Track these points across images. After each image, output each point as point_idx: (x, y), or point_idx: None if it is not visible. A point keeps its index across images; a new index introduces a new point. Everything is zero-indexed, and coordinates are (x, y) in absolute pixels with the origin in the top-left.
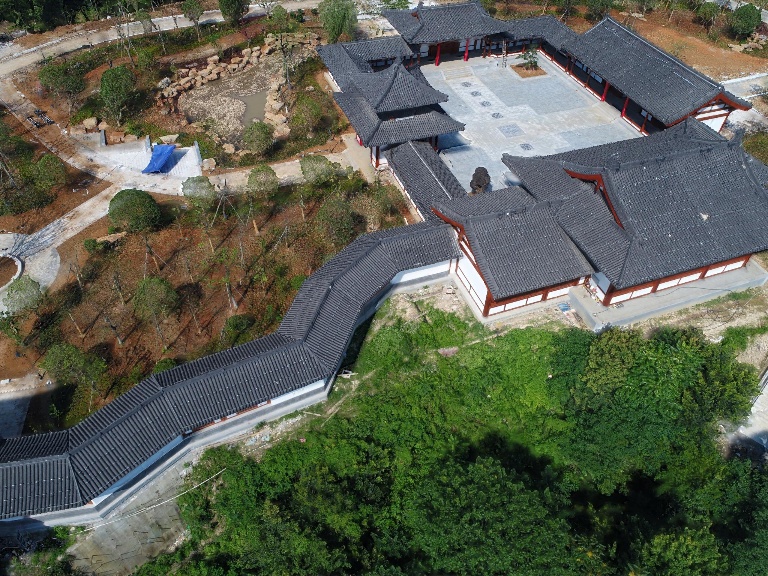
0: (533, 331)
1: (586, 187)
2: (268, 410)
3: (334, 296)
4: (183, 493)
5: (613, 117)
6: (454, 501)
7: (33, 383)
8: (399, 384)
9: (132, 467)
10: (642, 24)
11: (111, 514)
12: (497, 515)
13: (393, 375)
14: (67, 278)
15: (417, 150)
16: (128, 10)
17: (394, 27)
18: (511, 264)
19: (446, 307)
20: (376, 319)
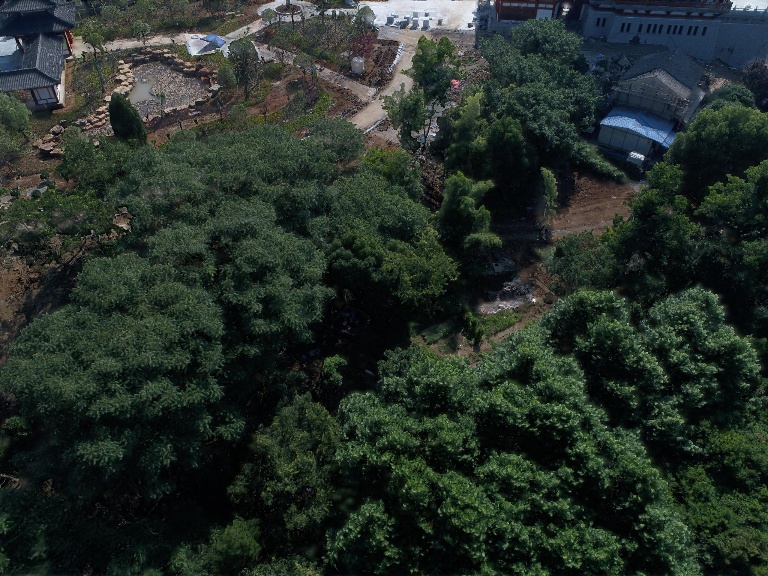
0: None
1: None
2: None
3: None
4: None
5: None
6: None
7: None
8: None
9: None
10: None
11: None
12: None
13: None
14: None
15: None
16: (361, 382)
17: None
18: None
19: None
20: None
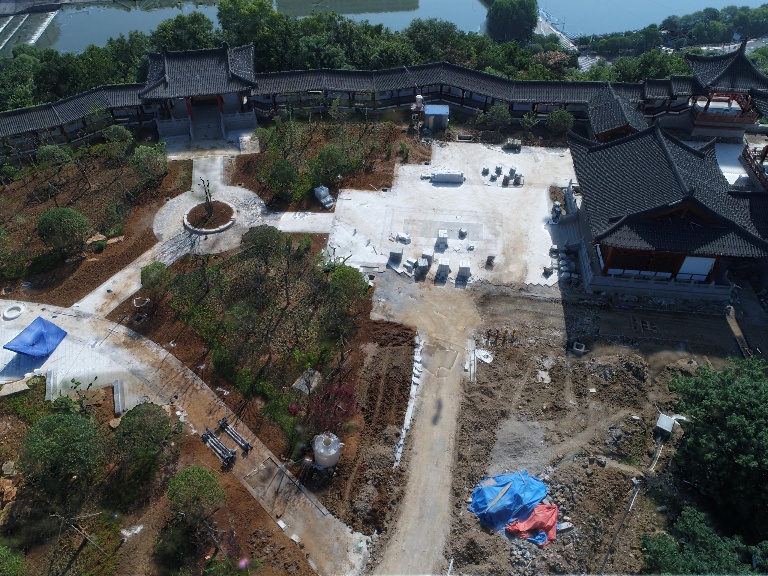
0: None
1: None
2: None
3: None
4: None
5: None
6: None
7: None
8: None
9: None
10: None
11: None
12: None
13: None
14: None
15: None
16: None
17: None
18: None
19: None
20: None
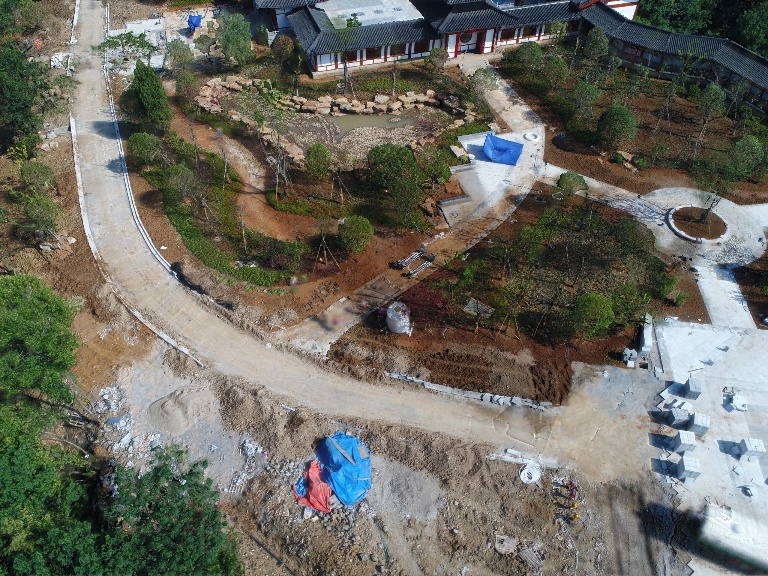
0: None
1: None
2: None
3: None
4: None
5: None
6: (766, 30)
7: None
8: None
9: None
10: None
11: None
12: None
13: None
14: None
15: (515, 7)
16: None
17: (289, 6)
18: None
19: None
20: None
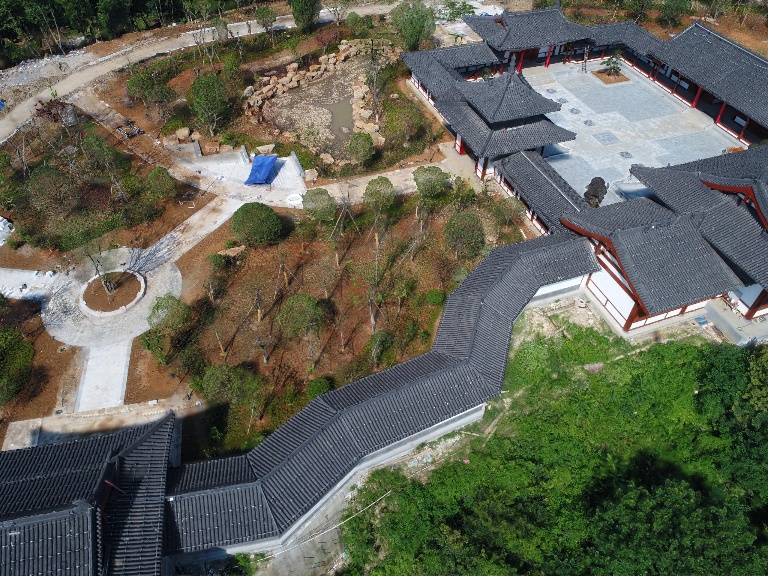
0: (676, 346)
1: (728, 199)
2: (430, 431)
3: (486, 313)
4: (351, 517)
5: (706, 124)
6: (648, 526)
7: (181, 404)
8: (556, 402)
9: (320, 493)
10: (715, 28)
11: (289, 540)
12: (709, 542)
13: (545, 393)
14: (196, 294)
15: (532, 160)
16: None
17: (477, 33)
18: (662, 279)
19: (582, 321)
20: (514, 334)
